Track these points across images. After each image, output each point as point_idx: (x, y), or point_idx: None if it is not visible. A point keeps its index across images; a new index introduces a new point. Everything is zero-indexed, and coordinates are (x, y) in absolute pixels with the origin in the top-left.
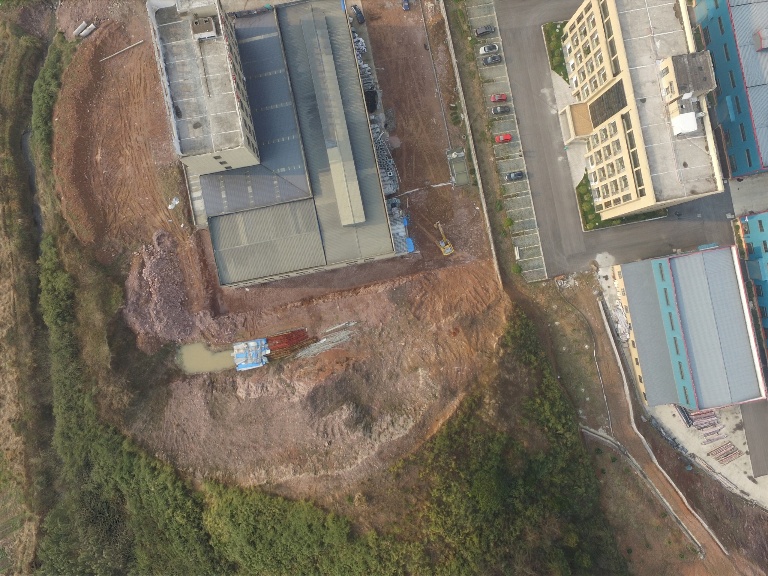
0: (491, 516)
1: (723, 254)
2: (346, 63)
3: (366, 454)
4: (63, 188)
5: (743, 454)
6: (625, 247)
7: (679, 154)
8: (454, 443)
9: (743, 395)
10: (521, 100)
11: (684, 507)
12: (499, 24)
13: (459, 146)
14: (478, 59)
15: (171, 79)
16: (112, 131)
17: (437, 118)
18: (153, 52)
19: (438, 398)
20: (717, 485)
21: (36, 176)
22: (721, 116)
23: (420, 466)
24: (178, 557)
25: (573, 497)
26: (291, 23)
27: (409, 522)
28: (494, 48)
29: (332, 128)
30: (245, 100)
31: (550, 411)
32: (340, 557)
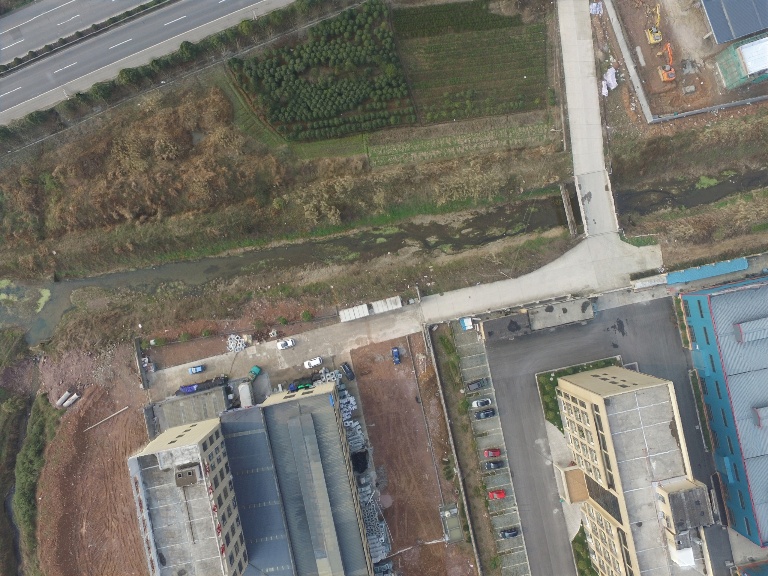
0: None
1: None
2: (335, 461)
3: None
4: (47, 572)
5: None
6: None
7: None
8: None
9: None
10: (515, 452)
11: None
12: (492, 374)
13: (452, 501)
14: (471, 411)
15: (155, 525)
16: (97, 503)
17: (429, 473)
18: (138, 417)
19: None
20: None
21: (20, 541)
22: (719, 467)
23: None
24: None
25: None
26: (278, 422)
27: None
28: (487, 403)
29: (321, 538)
30: (232, 512)
31: None
32: None
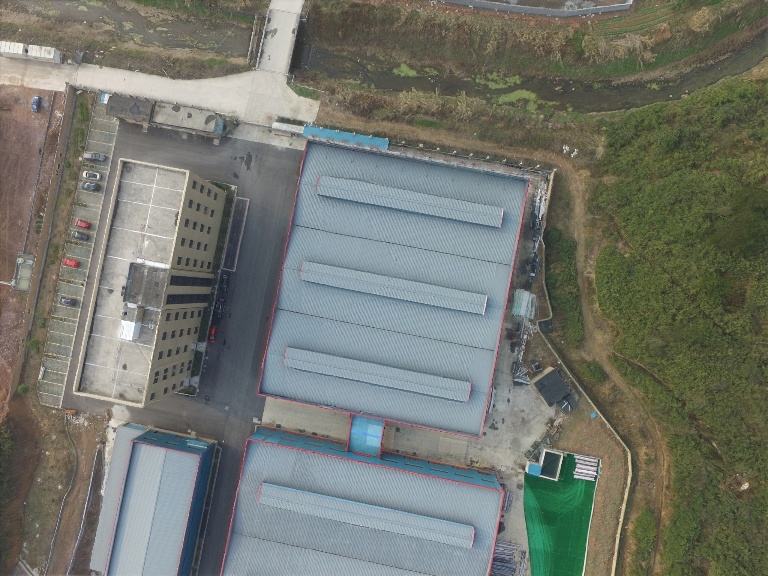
0: None
1: (190, 459)
2: None
3: None
4: None
5: None
6: (144, 409)
7: (123, 355)
8: None
9: None
10: None
11: None
12: (113, 155)
13: (33, 254)
14: (81, 180)
15: None
16: None
17: (24, 220)
18: None
19: None
20: None
21: None
22: None
23: None
24: None
25: None
26: None
27: None
28: (94, 176)
29: None
30: None
31: None
32: None
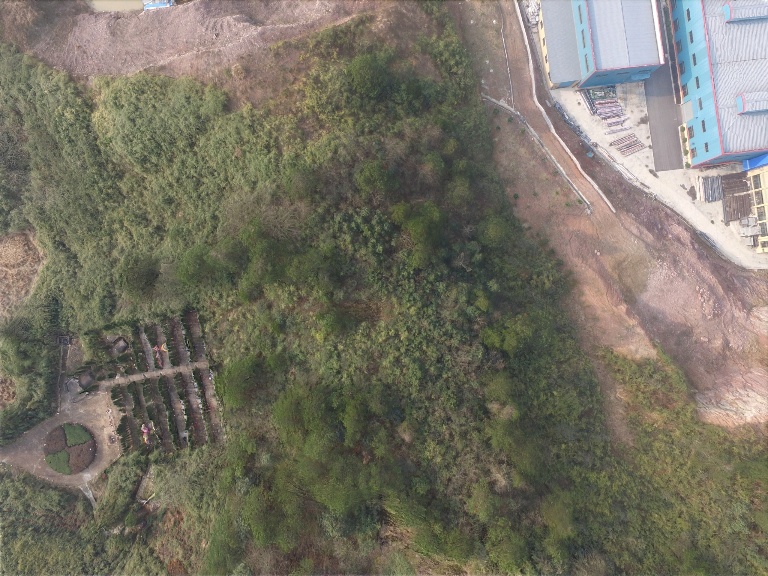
0: (369, 107)
1: None
2: None
3: (249, 34)
4: None
5: (646, 147)
6: None
7: None
8: (339, 39)
9: (642, 61)
10: None
11: (577, 171)
12: None
13: None
14: None
15: None
16: None
17: None
18: None
19: (331, 12)
20: (618, 175)
21: None
22: None
23: (301, 51)
24: (68, 168)
25: (461, 129)
26: None
27: (285, 96)
28: None
29: None
30: None
31: (445, 48)
32: (216, 132)
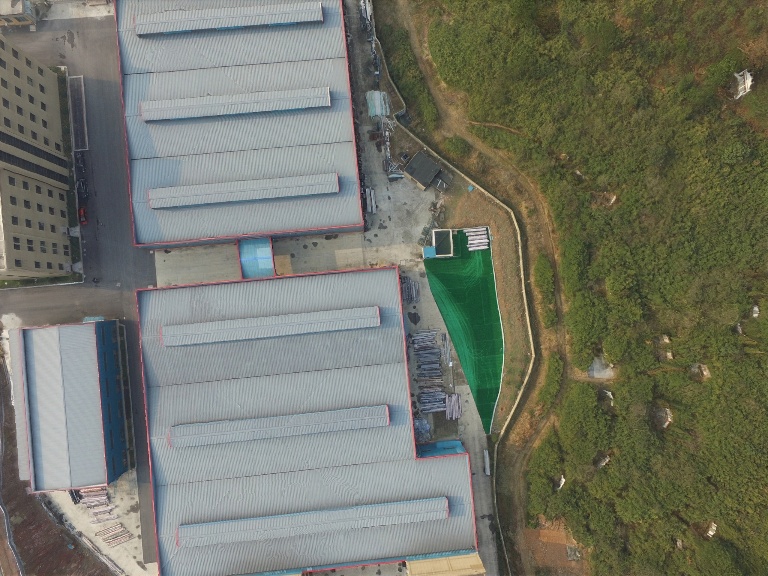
0: None
1: (86, 330)
2: None
3: None
4: None
5: (133, 538)
6: (34, 310)
7: None
8: None
9: (87, 480)
10: None
11: None
12: None
13: None
14: None
15: None
16: None
17: None
18: None
19: None
20: (102, 567)
21: None
22: None
23: None
24: None
25: None
26: None
27: None
28: None
29: None
30: None
31: None
32: None
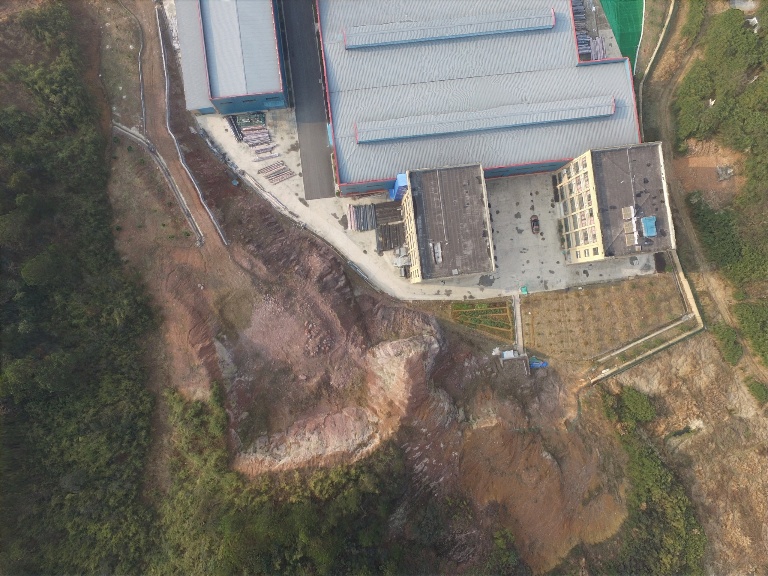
0: None
1: None
2: None
3: None
4: None
5: (295, 175)
6: None
7: None
8: None
9: (261, 88)
10: None
11: (198, 202)
12: None
13: None
14: None
15: None
16: None
17: None
18: None
19: None
20: (265, 204)
21: None
22: None
23: None
24: None
25: (51, 160)
26: None
27: None
28: None
29: None
30: None
31: (41, 76)
32: None
